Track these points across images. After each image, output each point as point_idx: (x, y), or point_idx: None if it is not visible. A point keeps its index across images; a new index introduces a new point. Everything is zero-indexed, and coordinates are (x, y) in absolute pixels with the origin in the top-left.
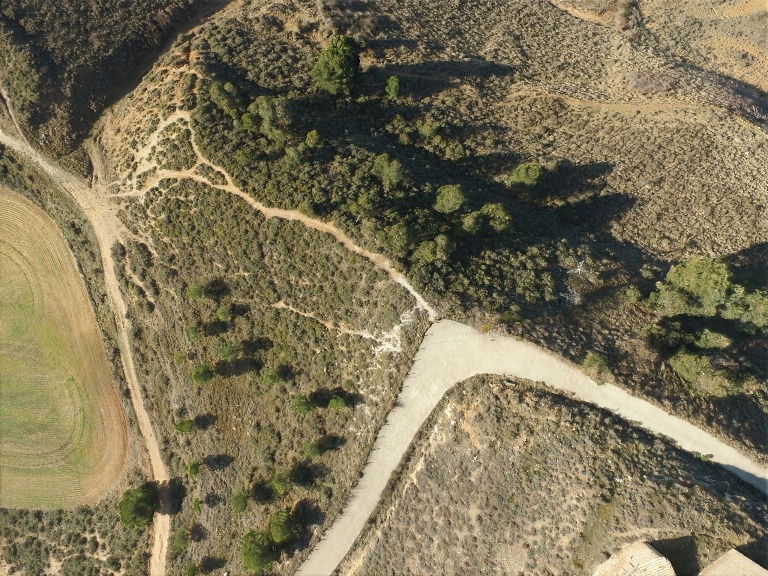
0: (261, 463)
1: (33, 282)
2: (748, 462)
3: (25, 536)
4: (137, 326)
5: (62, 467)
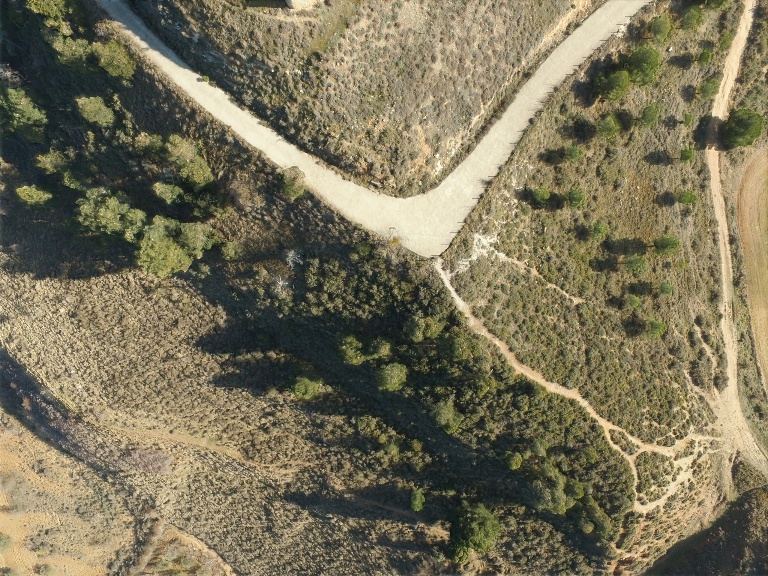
0: (619, 150)
1: None
2: (165, 68)
3: None
4: (713, 305)
5: None
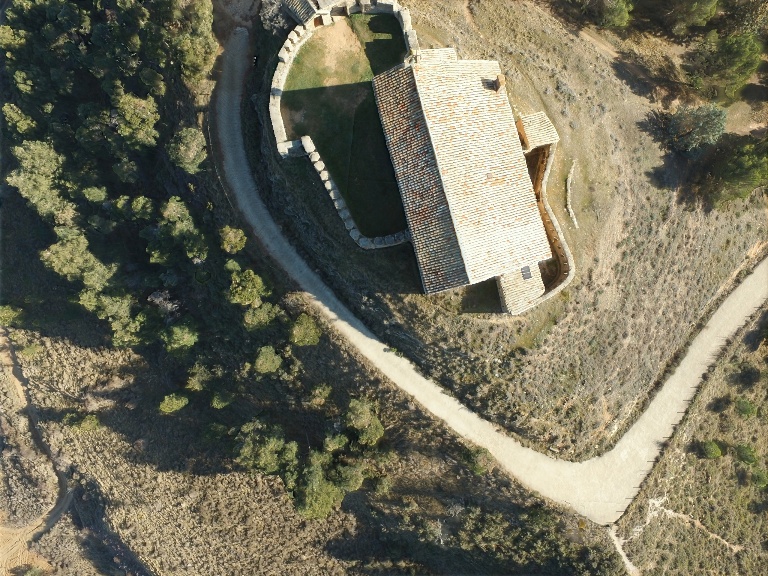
0: None
1: None
2: (352, 338)
3: None
4: None
5: None
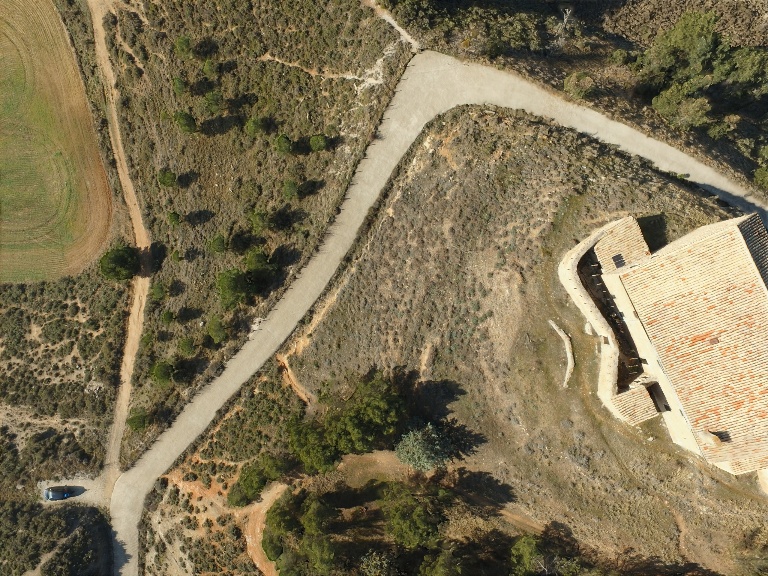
0: (241, 216)
1: (25, 58)
2: (724, 181)
3: (8, 307)
4: (125, 95)
5: (47, 241)
